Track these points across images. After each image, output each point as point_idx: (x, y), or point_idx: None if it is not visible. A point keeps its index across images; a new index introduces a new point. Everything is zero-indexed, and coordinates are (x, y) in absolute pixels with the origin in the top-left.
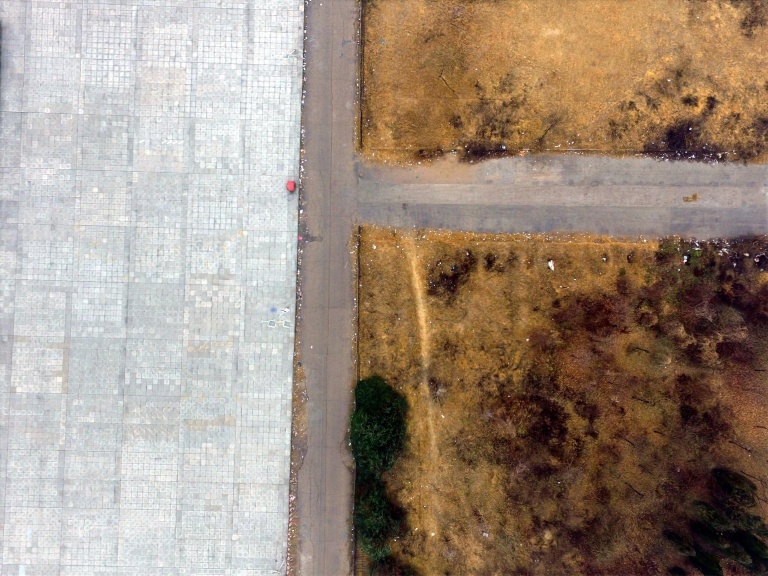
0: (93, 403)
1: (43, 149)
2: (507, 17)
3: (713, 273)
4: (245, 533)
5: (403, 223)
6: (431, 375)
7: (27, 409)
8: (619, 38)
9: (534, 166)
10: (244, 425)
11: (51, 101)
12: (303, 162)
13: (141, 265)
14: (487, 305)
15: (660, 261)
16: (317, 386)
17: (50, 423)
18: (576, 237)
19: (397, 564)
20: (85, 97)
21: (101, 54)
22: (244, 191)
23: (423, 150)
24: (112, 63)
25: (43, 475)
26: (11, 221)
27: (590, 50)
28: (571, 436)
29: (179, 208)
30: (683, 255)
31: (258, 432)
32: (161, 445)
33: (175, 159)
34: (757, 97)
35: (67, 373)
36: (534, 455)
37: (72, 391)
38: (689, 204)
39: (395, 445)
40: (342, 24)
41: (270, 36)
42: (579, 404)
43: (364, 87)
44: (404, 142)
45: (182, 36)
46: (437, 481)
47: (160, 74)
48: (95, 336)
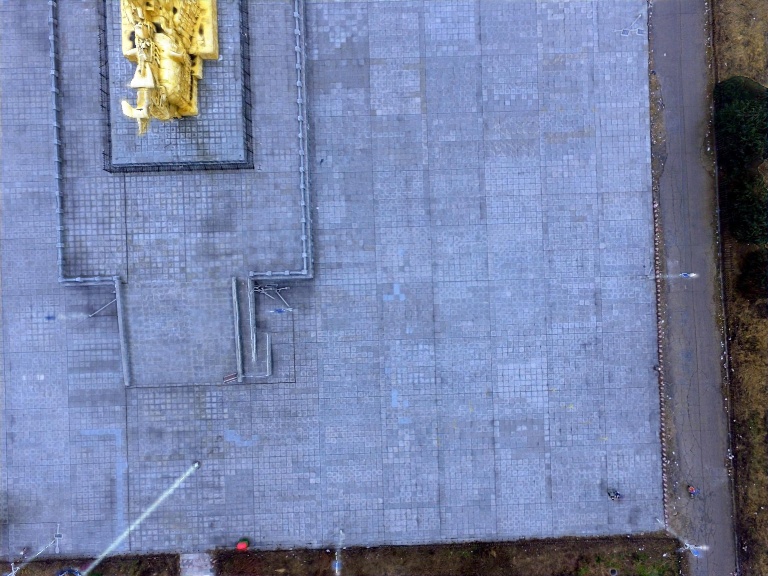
0: (453, 122)
1: None
2: None
3: None
4: (612, 241)
5: None
6: None
7: (388, 131)
8: None
9: None
10: (604, 135)
11: None
12: None
13: None
14: None
15: None
16: (673, 93)
17: (412, 144)
18: None
19: None
20: None
21: None
22: None
23: None
24: None
25: (409, 195)
26: None
27: None
28: None
29: None
30: None
31: (618, 141)
32: (523, 160)
33: None
34: None
35: (425, 93)
36: None
37: (431, 111)
38: None
39: None
40: None
41: None
42: None
43: None
44: None
45: None
46: None
47: None
48: (450, 55)
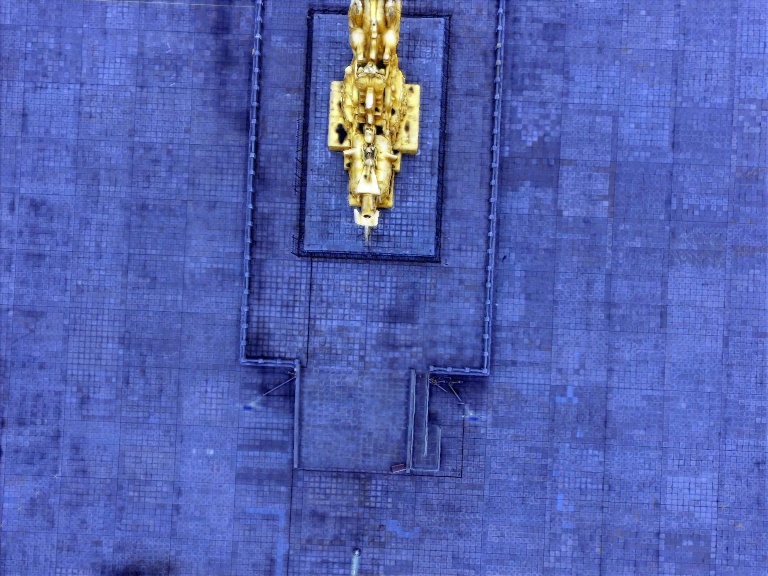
0: (639, 228)
1: None
2: None
3: None
4: None
5: None
6: None
7: (573, 233)
8: None
9: None
10: None
11: None
12: None
13: (689, 89)
14: None
15: None
16: None
17: (597, 247)
18: None
19: None
20: None
21: None
22: None
23: None
24: None
25: (590, 298)
26: (558, 44)
27: None
28: None
29: (728, 32)
30: None
31: None
32: (708, 271)
33: None
34: None
35: (613, 198)
36: None
37: (618, 215)
38: None
39: None
40: None
41: None
42: None
43: None
44: None
45: None
46: None
47: None
48: (641, 161)
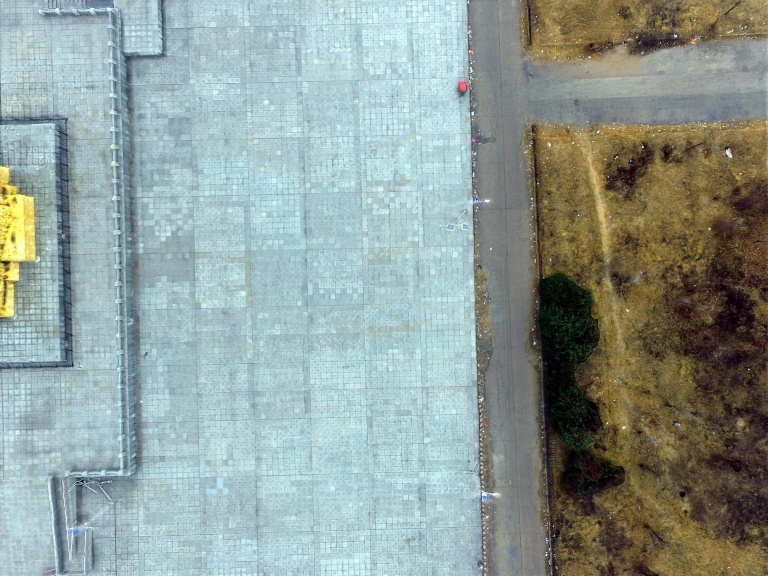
0: (278, 315)
1: (212, 64)
2: None
3: None
4: (436, 436)
5: (576, 119)
6: (613, 270)
7: (213, 324)
8: None
9: (707, 54)
10: (429, 329)
11: (216, 15)
12: (472, 63)
13: (317, 175)
14: (666, 196)
15: None
16: (499, 287)
17: (237, 337)
18: (753, 123)
19: (594, 456)
20: (250, 9)
21: None
22: (415, 95)
23: (594, 43)
24: None
25: (233, 389)
26: (185, 138)
27: None
28: (759, 322)
29: (351, 116)
30: None
31: (443, 336)
32: (348, 353)
33: (344, 67)
34: None
35: (250, 287)
36: (723, 343)
37: (256, 304)
38: None
39: (592, 335)
40: None
41: None
42: (765, 290)
43: None
44: (574, 36)
45: None
46: (625, 375)
47: None
48: (275, 249)
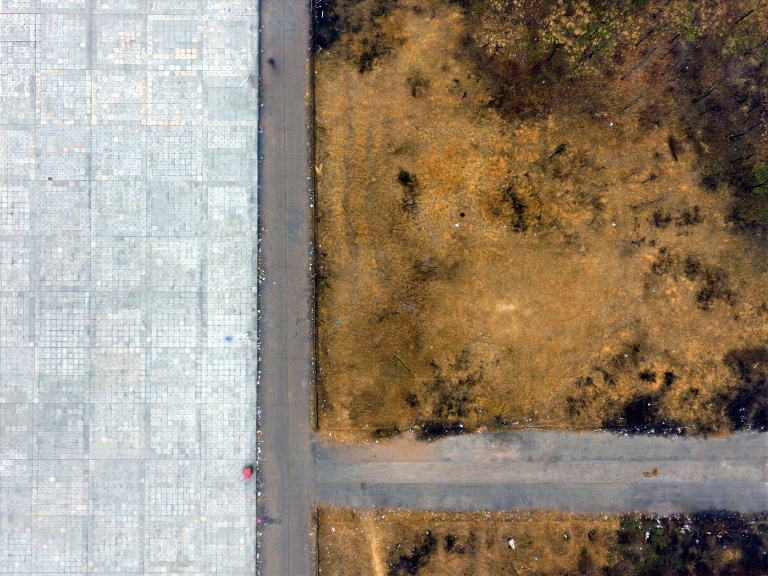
0: None
1: None
2: (461, 294)
3: (675, 551)
4: None
5: (362, 503)
6: None
7: None
8: (575, 313)
9: (492, 443)
10: None
11: (6, 391)
12: (260, 444)
13: (100, 554)
14: None
15: (622, 539)
16: None
17: None
18: (536, 515)
19: None
20: (40, 386)
21: (55, 342)
22: (201, 476)
23: (380, 430)
24: (66, 351)
25: None
26: None
27: (546, 325)
28: None
29: (136, 495)
30: (645, 532)
31: None
32: None
33: (131, 446)
34: (715, 372)
35: None
36: None
37: None
38: (650, 479)
39: None
40: (296, 302)
41: (224, 318)
42: None
43: (319, 367)
44: (361, 422)
45: (135, 321)
46: None
47: (114, 360)
48: None
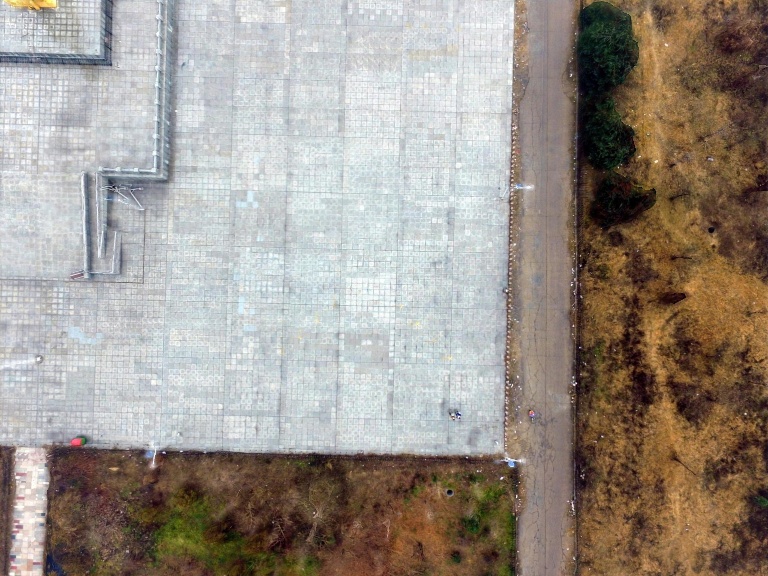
0: (316, 33)
1: None
2: None
3: None
4: (468, 161)
5: None
6: (654, 3)
7: (251, 39)
8: None
9: None
10: (466, 55)
11: None
12: None
13: None
14: None
15: None
16: (538, 18)
17: (274, 52)
18: None
19: None
20: None
21: None
22: None
23: None
24: None
25: (268, 104)
26: None
27: None
28: None
29: None
30: None
31: (480, 62)
32: (384, 75)
33: None
34: None
35: (290, 3)
36: (761, 78)
37: (295, 21)
38: None
39: (632, 50)
40: None
41: None
42: None
43: None
44: None
45: None
46: (660, 109)
47: None
48: None
